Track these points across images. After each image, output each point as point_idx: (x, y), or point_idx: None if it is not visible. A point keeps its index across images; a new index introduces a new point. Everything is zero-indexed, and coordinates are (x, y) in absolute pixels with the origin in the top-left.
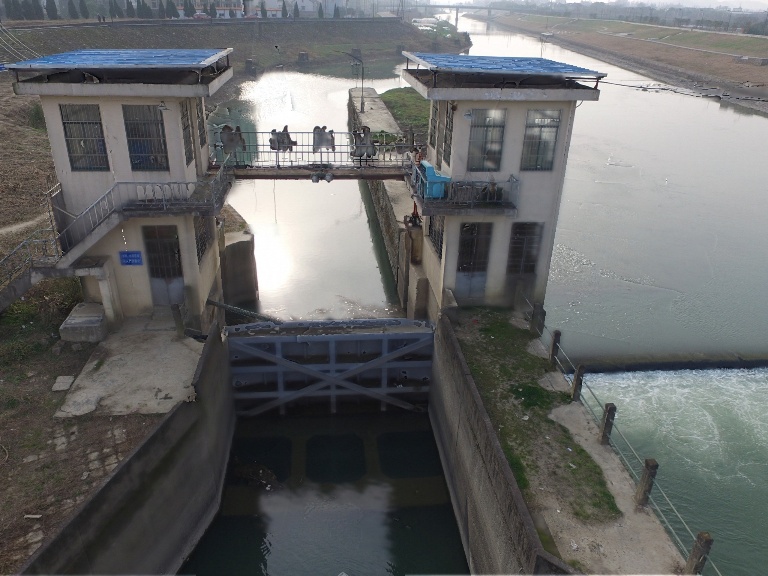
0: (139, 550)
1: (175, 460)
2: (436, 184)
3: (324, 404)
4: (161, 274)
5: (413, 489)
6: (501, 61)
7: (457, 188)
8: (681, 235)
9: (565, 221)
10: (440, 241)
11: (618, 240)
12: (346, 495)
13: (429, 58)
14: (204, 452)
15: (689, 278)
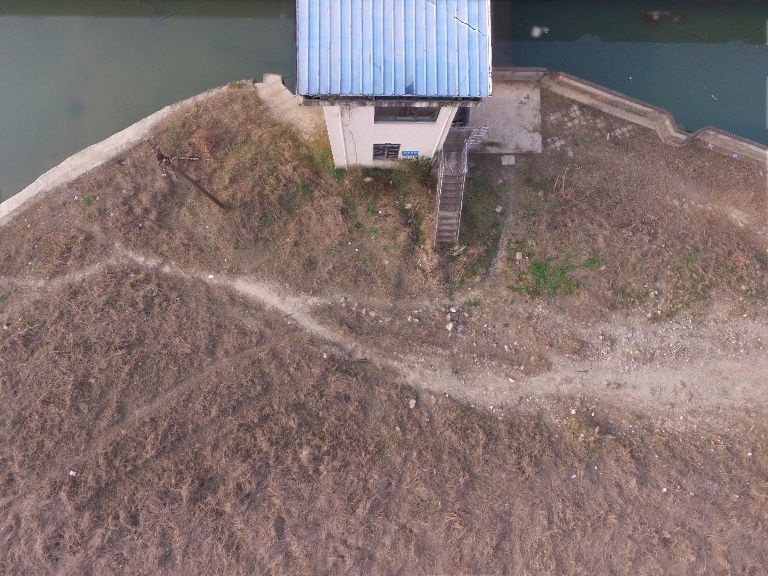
0: None
1: None
2: None
3: None
4: None
5: (500, 15)
6: None
7: None
8: None
9: None
10: None
11: None
12: (503, 49)
13: None
14: None
15: None
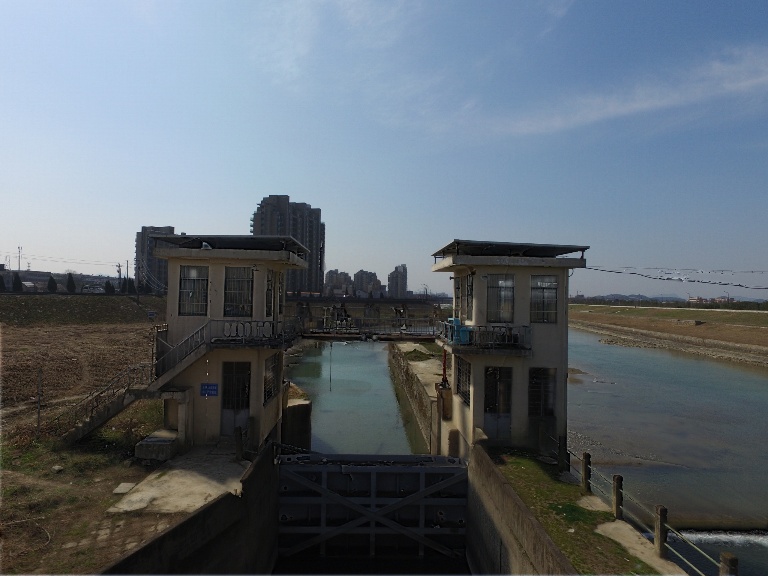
0: None
1: (210, 556)
2: (462, 333)
3: (363, 546)
4: (231, 405)
5: None
6: None
7: (480, 333)
8: (673, 427)
9: (568, 415)
10: (467, 390)
11: (618, 429)
12: None
13: None
14: (241, 561)
15: (692, 457)
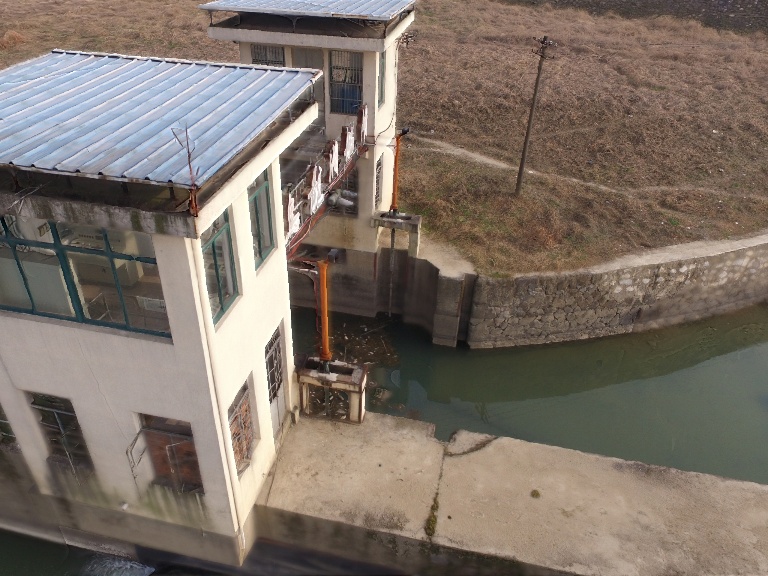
0: None
1: None
2: None
3: None
4: None
5: None
6: (127, 112)
7: None
8: None
9: None
10: None
11: None
12: None
13: (206, 72)
14: None
15: None
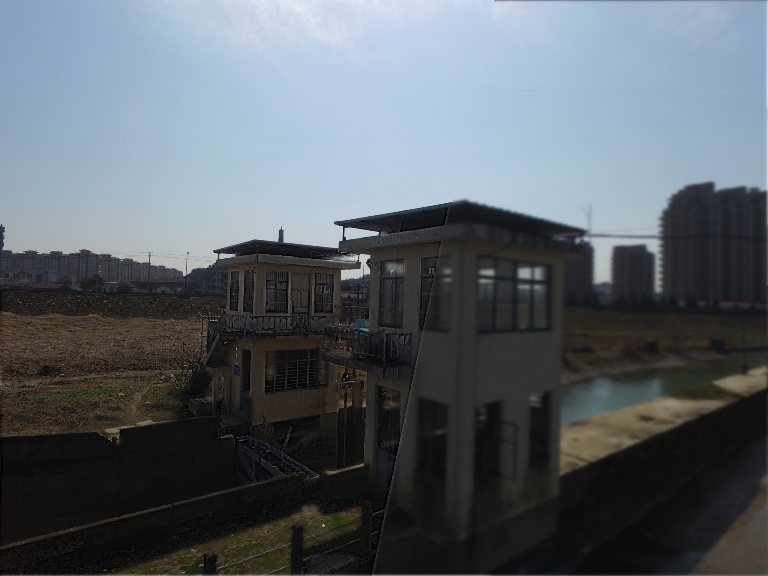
0: (5, 508)
1: (68, 469)
2: None
3: None
4: None
5: None
6: None
7: (352, 338)
8: None
9: None
10: None
11: None
12: None
13: None
14: (108, 488)
15: None
